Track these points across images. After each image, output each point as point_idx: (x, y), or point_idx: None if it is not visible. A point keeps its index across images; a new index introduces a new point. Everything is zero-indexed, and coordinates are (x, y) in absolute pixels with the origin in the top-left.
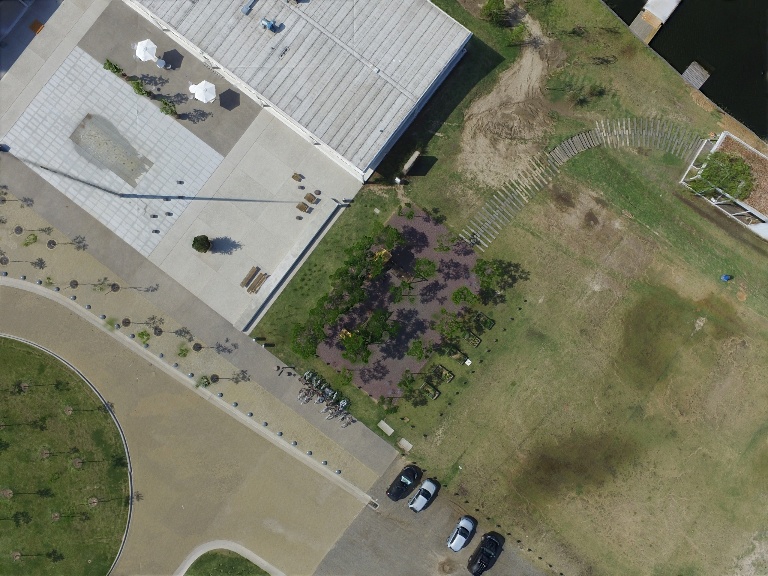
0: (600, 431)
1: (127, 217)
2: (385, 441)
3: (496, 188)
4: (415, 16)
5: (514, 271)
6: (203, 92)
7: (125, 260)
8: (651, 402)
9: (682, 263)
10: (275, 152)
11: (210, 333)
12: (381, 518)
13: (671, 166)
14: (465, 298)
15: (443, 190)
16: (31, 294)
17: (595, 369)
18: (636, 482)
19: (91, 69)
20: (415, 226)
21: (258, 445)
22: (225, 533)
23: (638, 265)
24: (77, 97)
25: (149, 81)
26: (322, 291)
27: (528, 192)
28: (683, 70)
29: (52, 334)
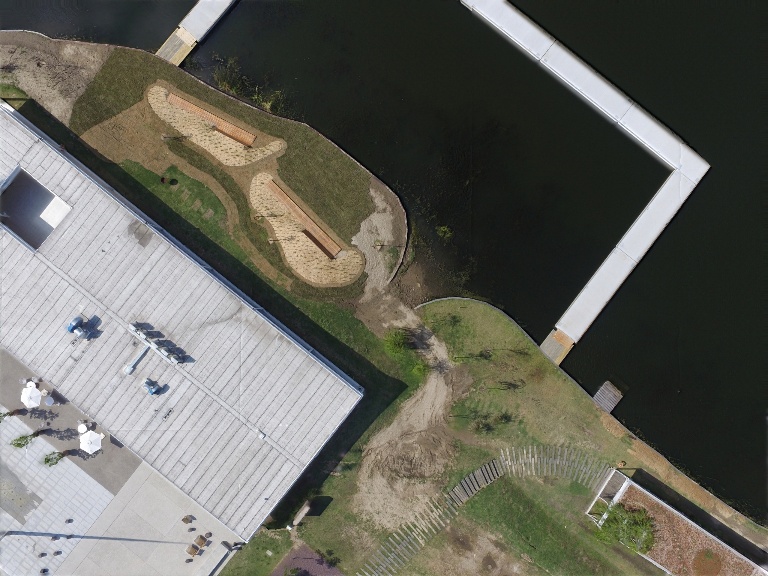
0: None
1: (16, 554)
2: None
3: (392, 530)
4: (304, 377)
5: None
6: (88, 445)
7: None
8: None
9: None
10: (166, 492)
11: None
12: None
13: (577, 496)
14: None
15: (337, 532)
16: None
17: None
18: None
19: None
20: (308, 569)
21: None
22: None
23: None
24: None
25: (39, 415)
26: None
27: (425, 535)
28: (595, 391)
29: None
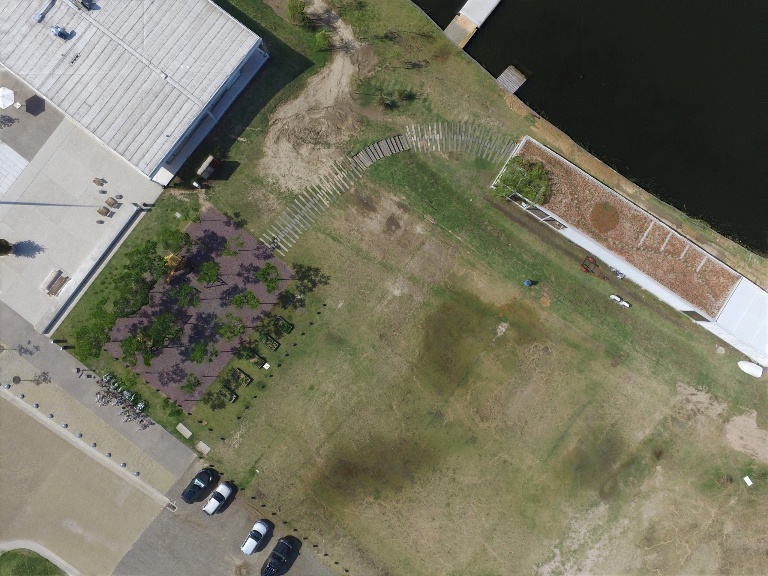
0: (399, 436)
1: None
2: (183, 444)
3: (297, 193)
4: (204, 22)
5: (314, 275)
6: (0, 98)
7: None
8: (451, 408)
9: (485, 268)
10: (79, 157)
11: (13, 335)
12: (179, 520)
13: (482, 170)
14: (248, 302)
15: (245, 195)
16: None
17: (394, 374)
18: (435, 488)
19: None
20: (216, 230)
21: (59, 446)
22: (26, 533)
23: (439, 270)
24: None
25: None
26: None
27: (329, 197)
28: (499, 74)
29: None
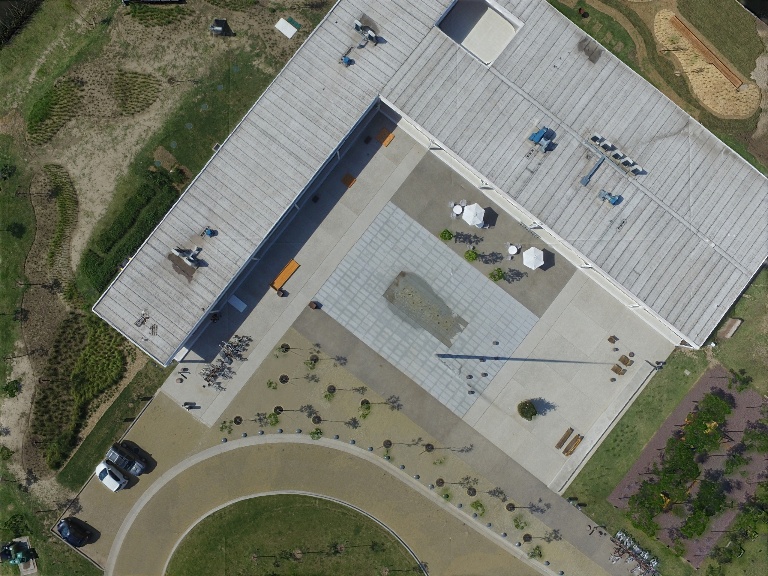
0: None
1: (442, 377)
2: None
3: None
4: (749, 190)
5: None
6: (533, 260)
7: (439, 420)
8: None
9: None
10: (589, 313)
11: (523, 493)
12: None
13: None
14: None
15: (749, 351)
16: (344, 454)
17: None
18: None
19: (404, 225)
20: (723, 387)
21: None
22: None
23: None
24: (390, 254)
25: (463, 239)
26: (633, 451)
27: None
28: None
29: (366, 494)
